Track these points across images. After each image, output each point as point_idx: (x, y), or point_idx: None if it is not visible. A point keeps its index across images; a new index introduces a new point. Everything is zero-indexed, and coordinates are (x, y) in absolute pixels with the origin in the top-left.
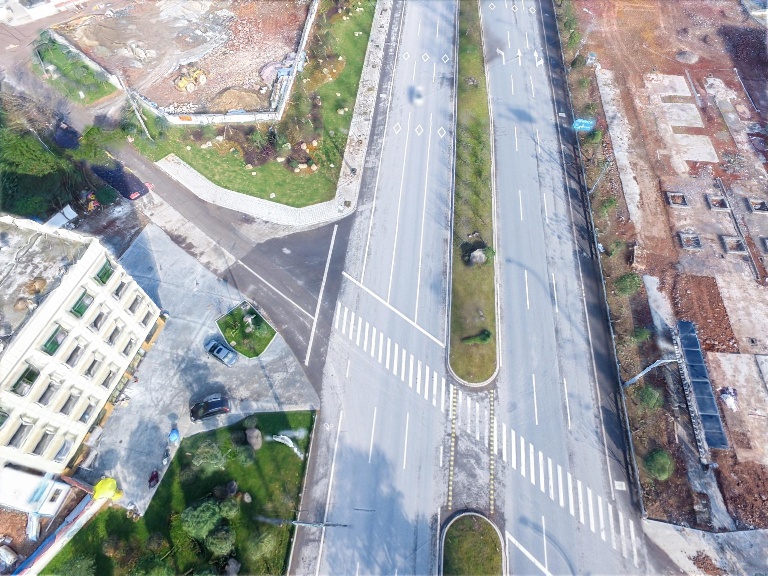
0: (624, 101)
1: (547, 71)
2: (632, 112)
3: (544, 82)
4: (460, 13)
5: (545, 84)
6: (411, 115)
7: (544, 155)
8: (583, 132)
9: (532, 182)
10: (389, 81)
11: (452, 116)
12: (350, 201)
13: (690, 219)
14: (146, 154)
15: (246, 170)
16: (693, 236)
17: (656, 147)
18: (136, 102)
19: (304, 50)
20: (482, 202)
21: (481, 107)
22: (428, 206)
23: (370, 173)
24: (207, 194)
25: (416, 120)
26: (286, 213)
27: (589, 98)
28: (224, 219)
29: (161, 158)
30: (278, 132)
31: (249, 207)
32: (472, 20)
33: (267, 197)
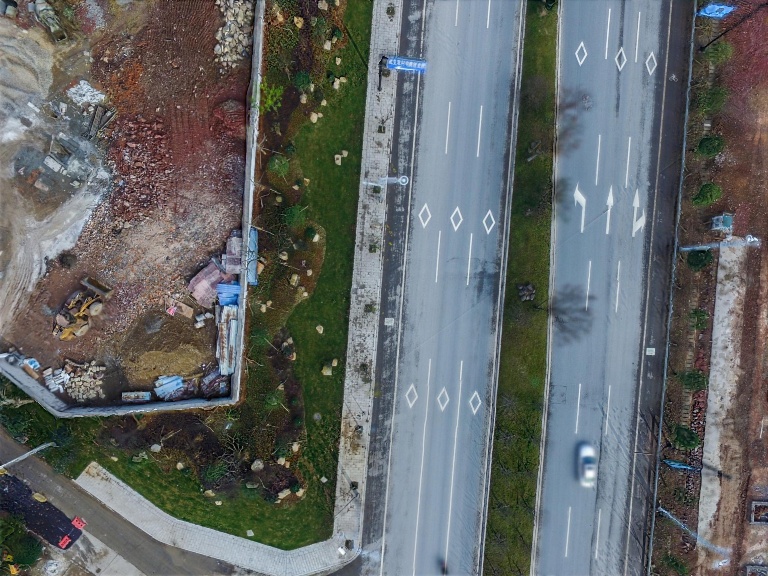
0: (746, 314)
1: (647, 246)
2: (751, 339)
3: (637, 275)
4: (522, 86)
5: (638, 280)
6: (432, 366)
7: (611, 439)
8: (673, 388)
9: (588, 491)
10: (398, 285)
11: (492, 367)
12: (353, 540)
13: (767, 542)
14: (55, 465)
15: (207, 497)
16: (762, 570)
17: (763, 413)
18: (6, 395)
19: (252, 223)
20: (521, 539)
21: (536, 351)
22: (452, 541)
23: (376, 487)
24: (162, 532)
25: (439, 377)
26: (272, 559)
27: (697, 309)
28: (194, 571)
29: (80, 472)
30: (240, 432)
31: (222, 550)
32: (542, 112)
33: (243, 535)
